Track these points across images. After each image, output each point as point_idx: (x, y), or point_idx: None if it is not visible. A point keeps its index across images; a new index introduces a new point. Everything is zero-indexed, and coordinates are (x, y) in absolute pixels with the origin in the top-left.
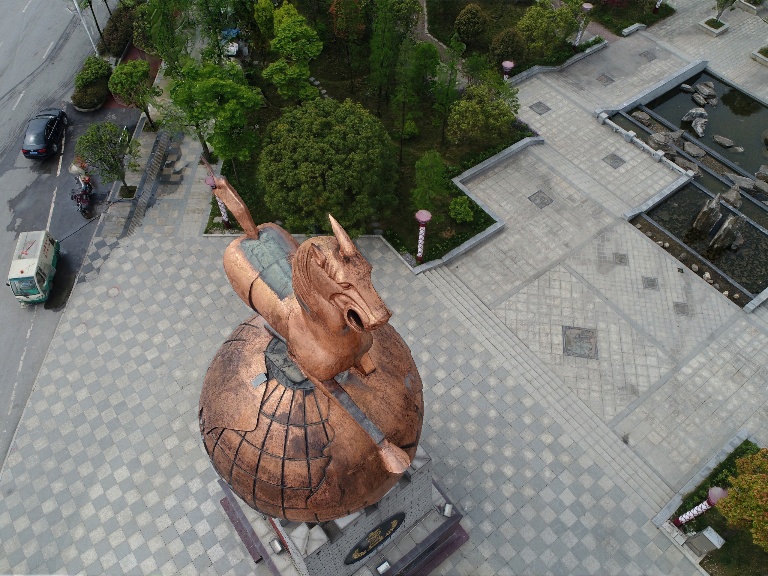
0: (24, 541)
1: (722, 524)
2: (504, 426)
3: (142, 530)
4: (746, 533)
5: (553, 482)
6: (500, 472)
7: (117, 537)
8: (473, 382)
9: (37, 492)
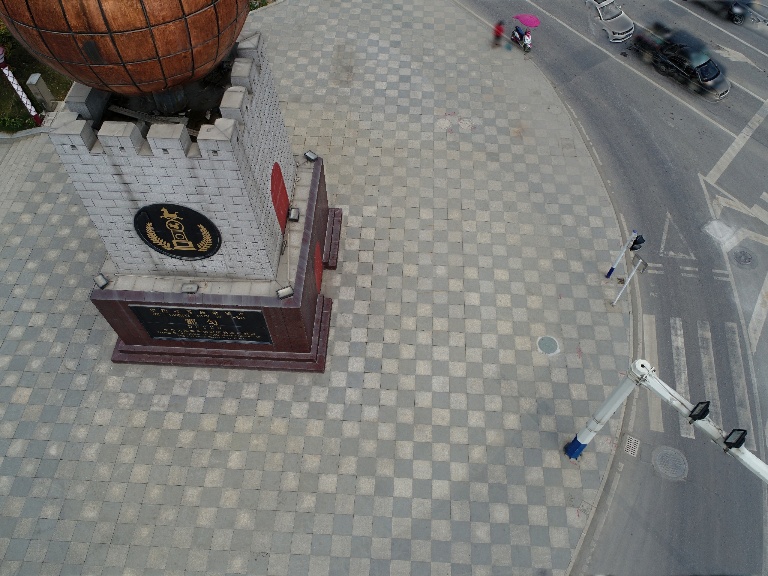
0: (540, 490)
1: (19, 106)
2: (39, 250)
3: (413, 405)
4: (16, 97)
5: (68, 192)
6: (90, 224)
7: (440, 417)
8: (4, 302)
9: (509, 545)
